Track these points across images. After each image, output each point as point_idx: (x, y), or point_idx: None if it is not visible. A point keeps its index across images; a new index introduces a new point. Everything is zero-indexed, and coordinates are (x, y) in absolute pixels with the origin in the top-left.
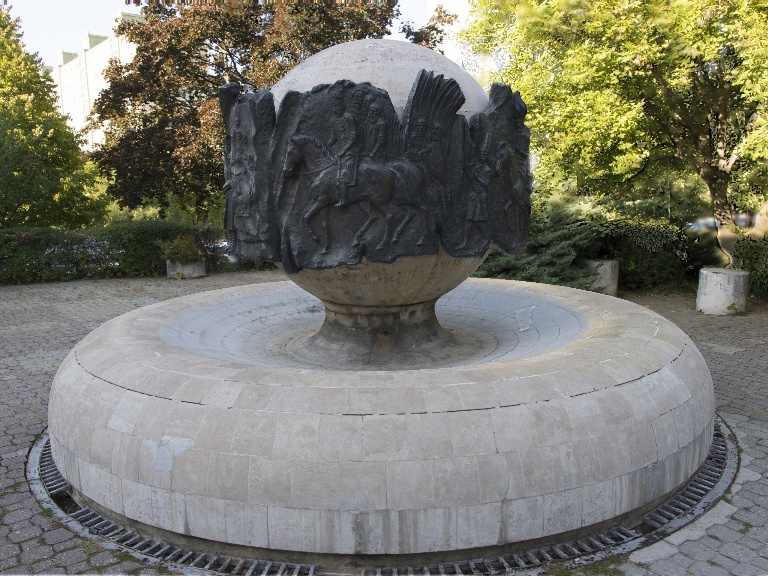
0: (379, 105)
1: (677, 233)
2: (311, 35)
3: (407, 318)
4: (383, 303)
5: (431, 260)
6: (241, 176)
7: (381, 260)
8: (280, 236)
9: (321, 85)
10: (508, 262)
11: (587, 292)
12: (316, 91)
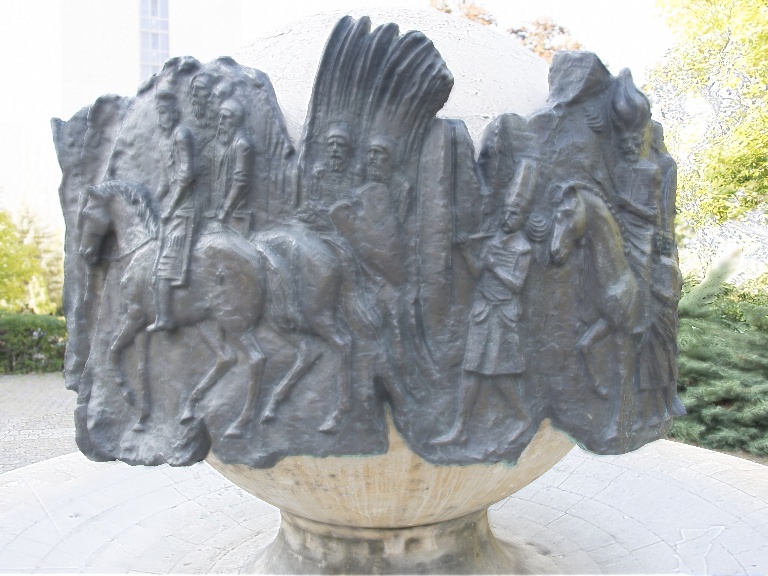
0: (239, 103)
1: None
2: None
3: (400, 552)
4: (337, 522)
5: (400, 454)
6: None
7: (238, 460)
8: None
9: (149, 75)
10: (729, 390)
11: None
12: (142, 89)
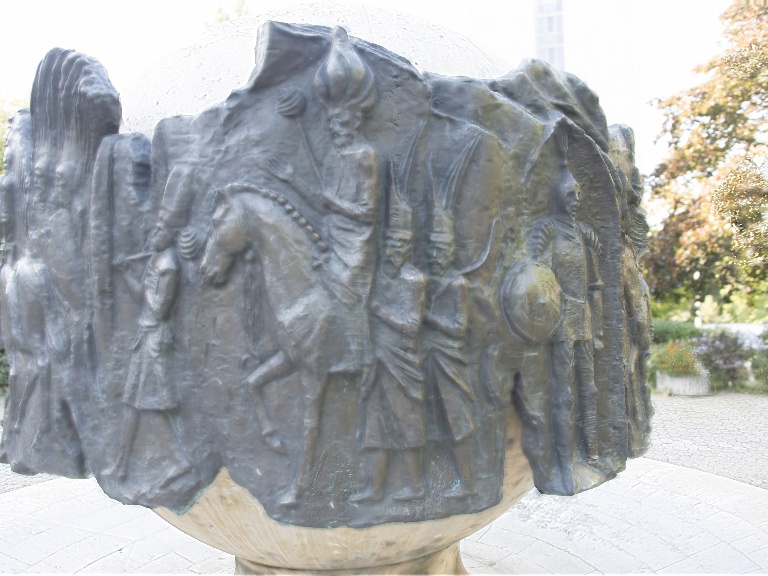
0: (11, 148)
1: None
2: None
3: None
4: None
5: None
6: None
7: None
8: None
9: None
10: None
11: None
12: None
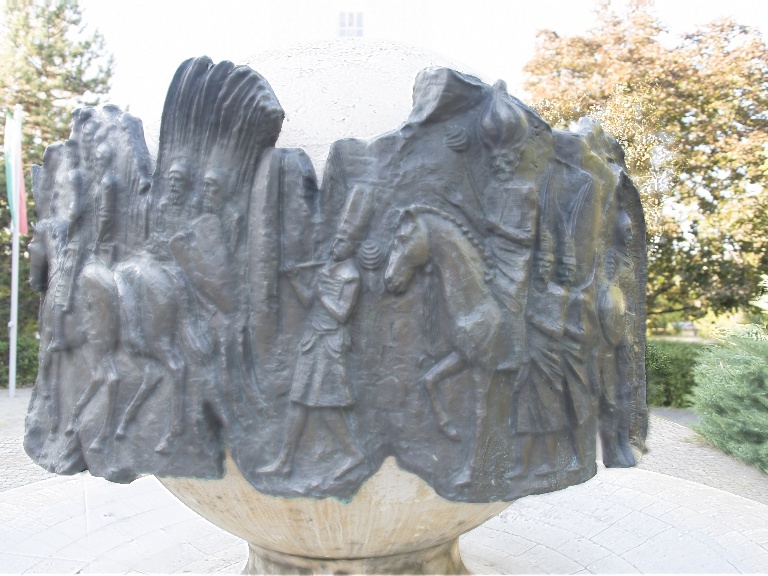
0: (108, 145)
1: None
2: (660, 116)
3: None
4: None
5: None
6: None
7: (99, 473)
8: None
9: None
10: None
11: None
12: None
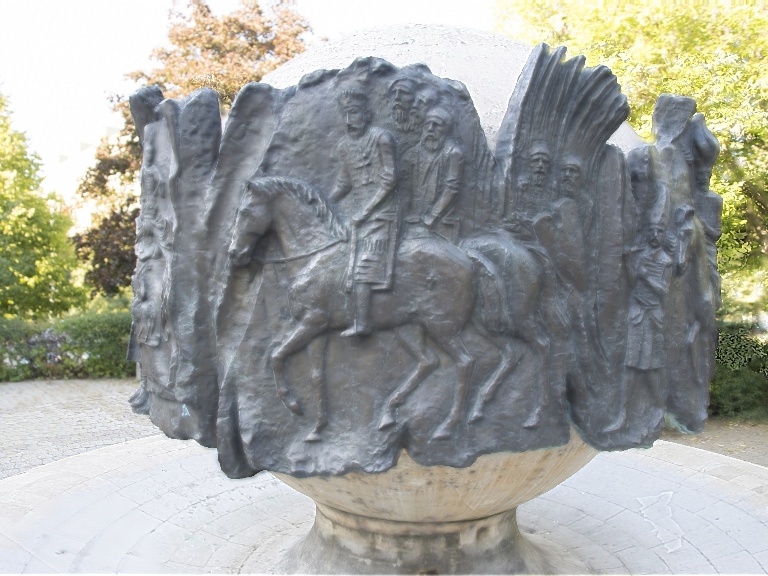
0: (448, 112)
1: (762, 347)
2: None
3: (472, 542)
4: (429, 519)
5: None
6: (149, 262)
7: (443, 461)
8: (219, 392)
9: (319, 71)
10: None
11: (754, 467)
12: (308, 84)
